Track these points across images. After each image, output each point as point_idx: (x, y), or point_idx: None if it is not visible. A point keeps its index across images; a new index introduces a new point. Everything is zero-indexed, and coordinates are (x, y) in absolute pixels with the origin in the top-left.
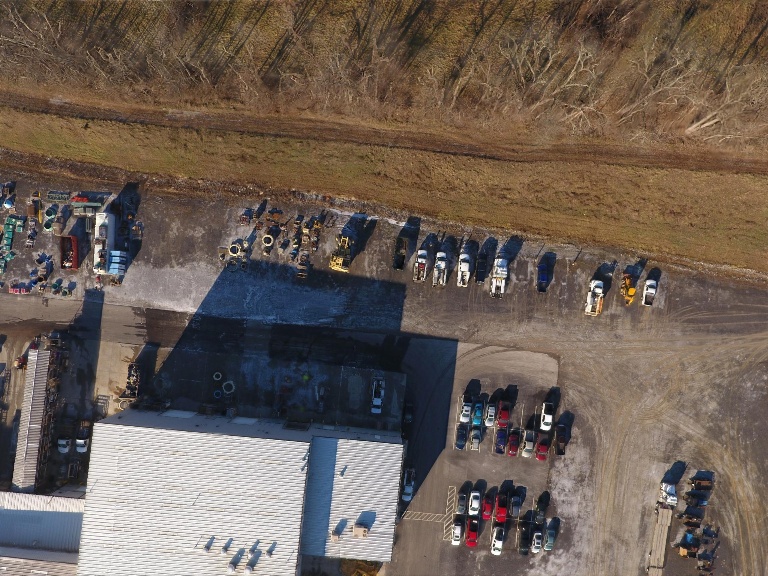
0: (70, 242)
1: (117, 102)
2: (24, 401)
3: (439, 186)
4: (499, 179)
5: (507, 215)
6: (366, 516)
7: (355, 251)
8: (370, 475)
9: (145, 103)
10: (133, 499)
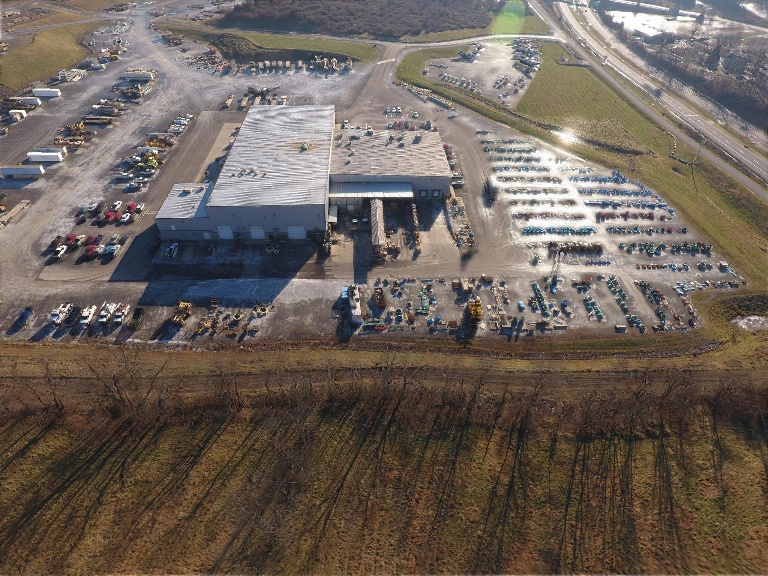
0: None
1: None
2: None
3: None
4: (29, 367)
5: None
6: (184, 195)
7: None
8: (178, 208)
9: None
10: (303, 184)
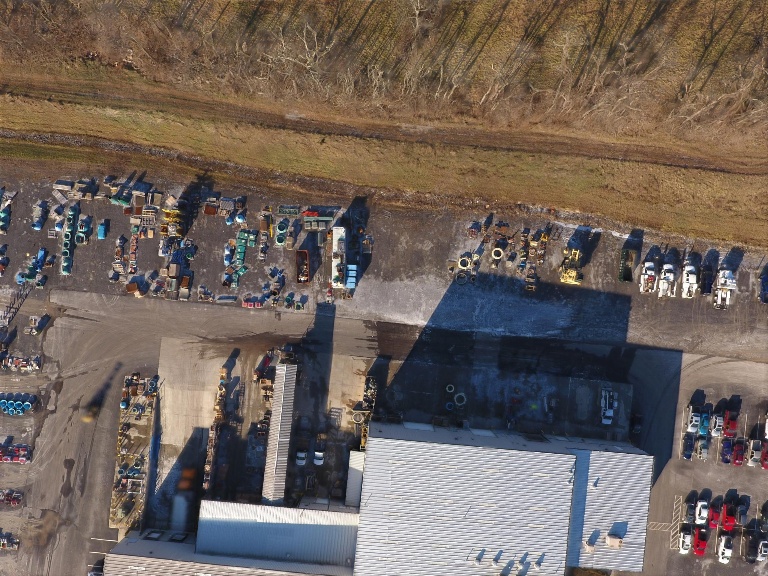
0: (302, 256)
1: (352, 117)
2: (273, 415)
3: (665, 199)
4: (727, 192)
5: (730, 227)
6: (618, 527)
7: (581, 263)
8: (622, 486)
9: (380, 118)
10: (406, 512)
